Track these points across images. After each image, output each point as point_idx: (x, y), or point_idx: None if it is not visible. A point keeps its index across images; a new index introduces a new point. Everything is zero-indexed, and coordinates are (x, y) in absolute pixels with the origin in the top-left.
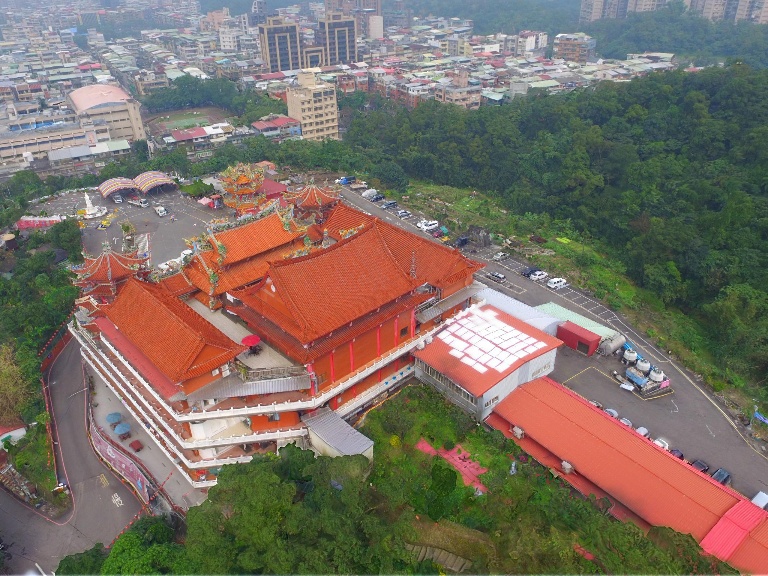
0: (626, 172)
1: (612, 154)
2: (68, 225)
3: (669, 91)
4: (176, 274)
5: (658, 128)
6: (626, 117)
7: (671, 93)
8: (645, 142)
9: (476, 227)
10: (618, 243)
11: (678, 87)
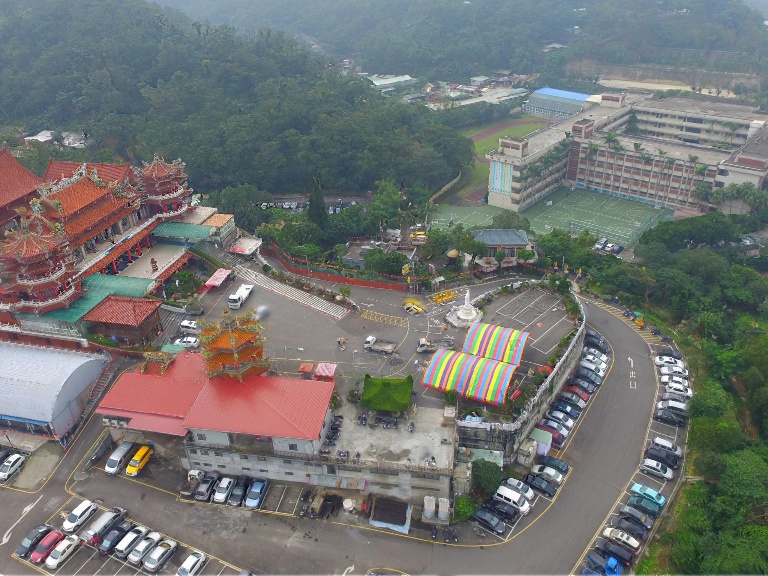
0: None
1: None
2: (385, 256)
3: None
4: (121, 190)
5: None
6: None
7: None
8: None
9: None
10: None
11: None
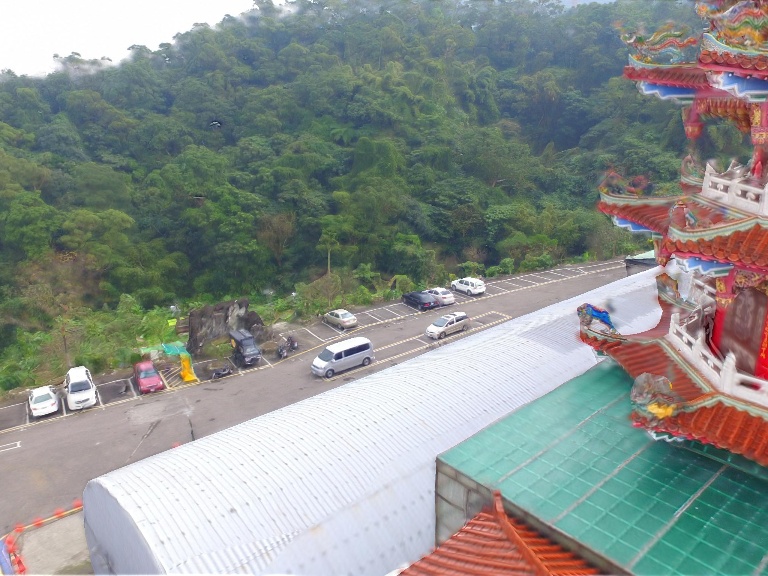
0: (173, 179)
1: (83, 179)
2: None
3: (34, 94)
4: None
5: (74, 143)
6: (1, 140)
7: (36, 98)
8: (73, 166)
9: (211, 309)
10: (243, 283)
11: (36, 90)
